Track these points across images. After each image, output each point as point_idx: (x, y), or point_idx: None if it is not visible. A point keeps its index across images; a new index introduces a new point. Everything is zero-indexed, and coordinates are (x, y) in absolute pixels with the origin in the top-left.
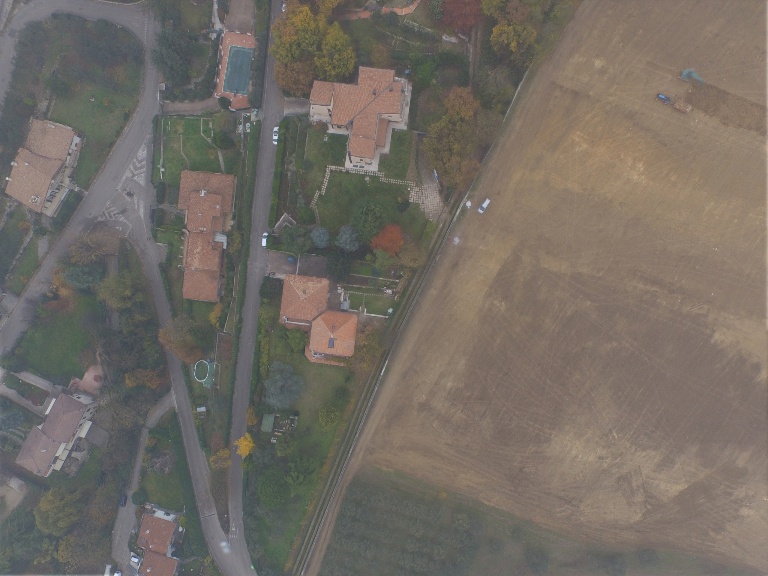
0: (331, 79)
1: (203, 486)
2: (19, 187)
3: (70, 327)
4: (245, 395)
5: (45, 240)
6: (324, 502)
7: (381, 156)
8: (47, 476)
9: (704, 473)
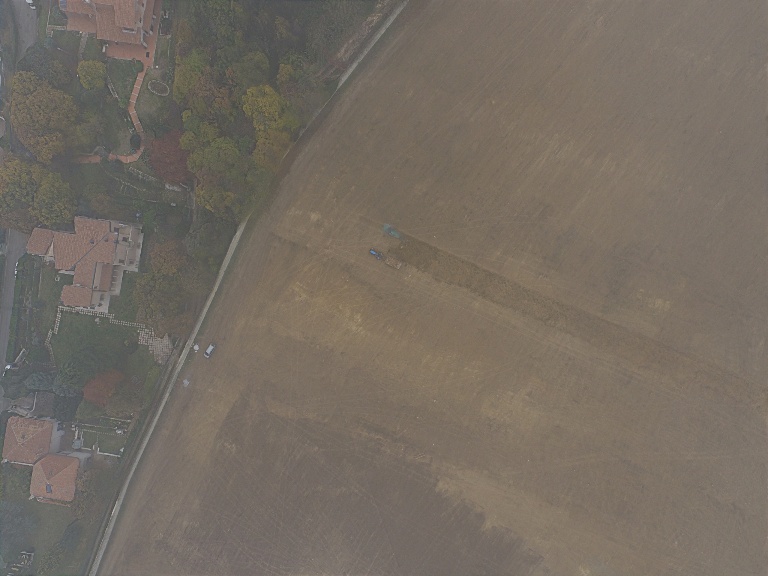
0: (50, 227)
1: None
2: None
3: None
4: None
5: None
6: None
7: (111, 298)
8: None
9: None
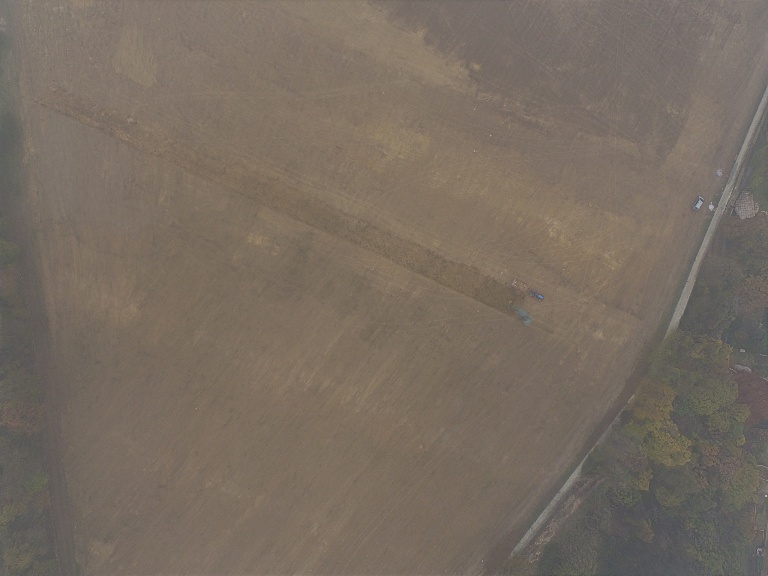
0: None
1: None
2: None
3: None
4: None
5: None
6: None
7: None
8: None
9: None
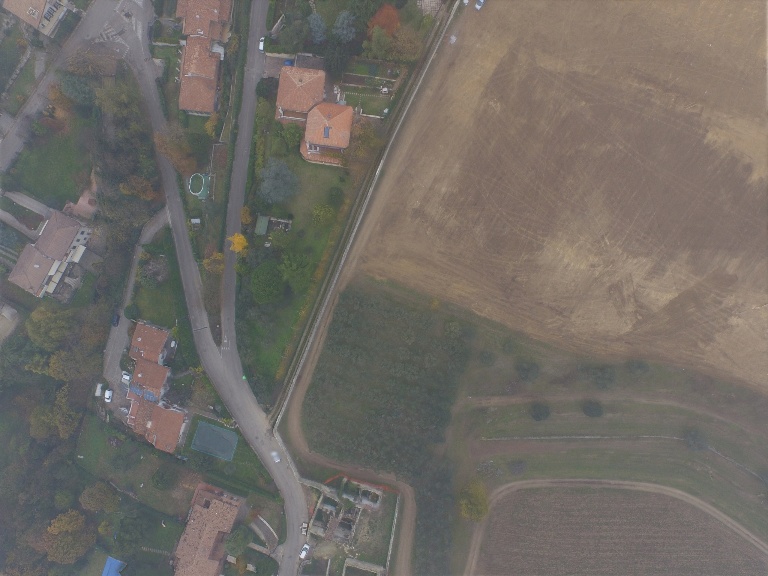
0: None
1: (196, 300)
2: (17, 0)
3: (65, 150)
4: (240, 202)
5: (42, 61)
6: (316, 312)
7: None
8: (40, 297)
9: (694, 281)
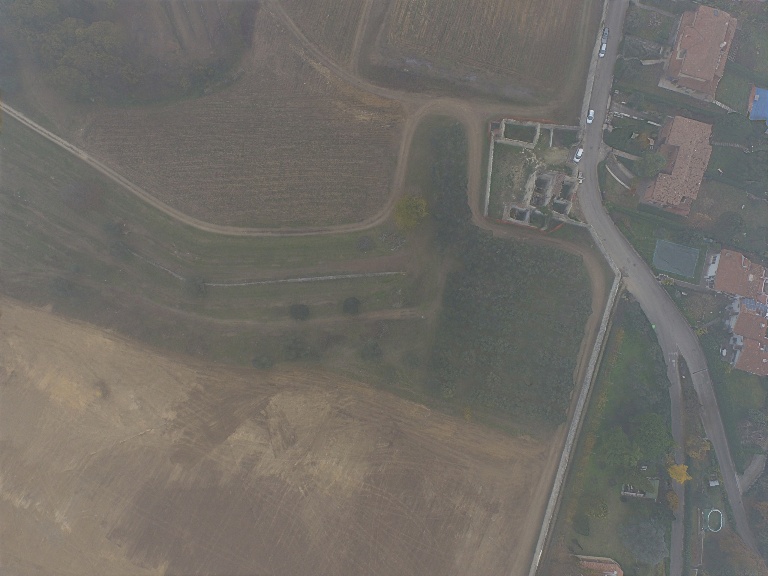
0: None
1: (706, 400)
2: None
3: None
4: None
5: None
6: None
7: None
8: None
9: (212, 454)
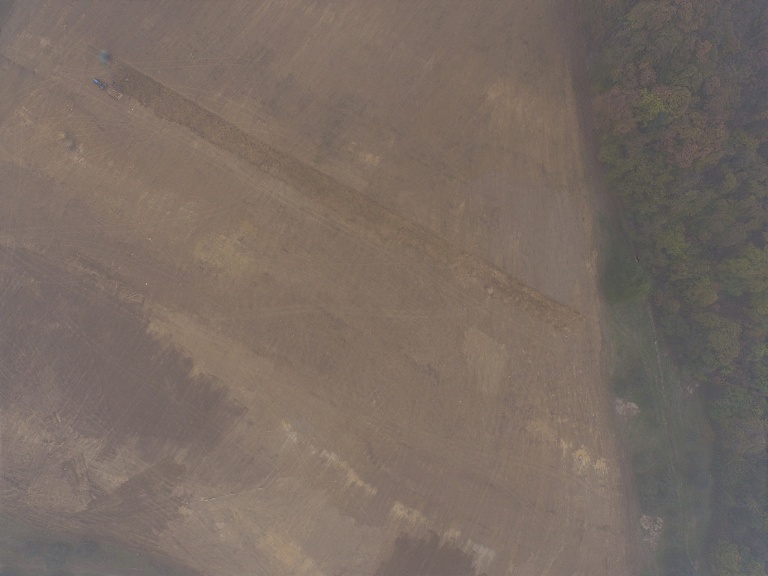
0: None
1: None
2: None
3: None
4: None
5: None
6: None
7: None
8: None
9: (144, 467)
